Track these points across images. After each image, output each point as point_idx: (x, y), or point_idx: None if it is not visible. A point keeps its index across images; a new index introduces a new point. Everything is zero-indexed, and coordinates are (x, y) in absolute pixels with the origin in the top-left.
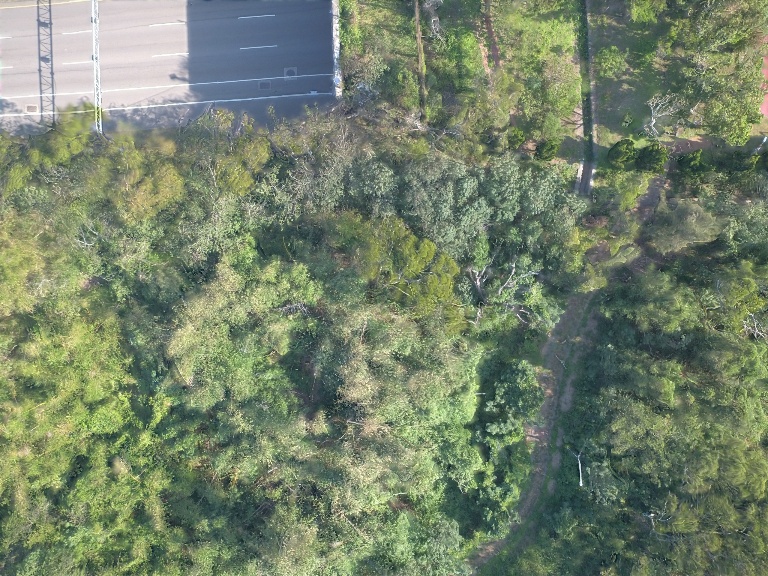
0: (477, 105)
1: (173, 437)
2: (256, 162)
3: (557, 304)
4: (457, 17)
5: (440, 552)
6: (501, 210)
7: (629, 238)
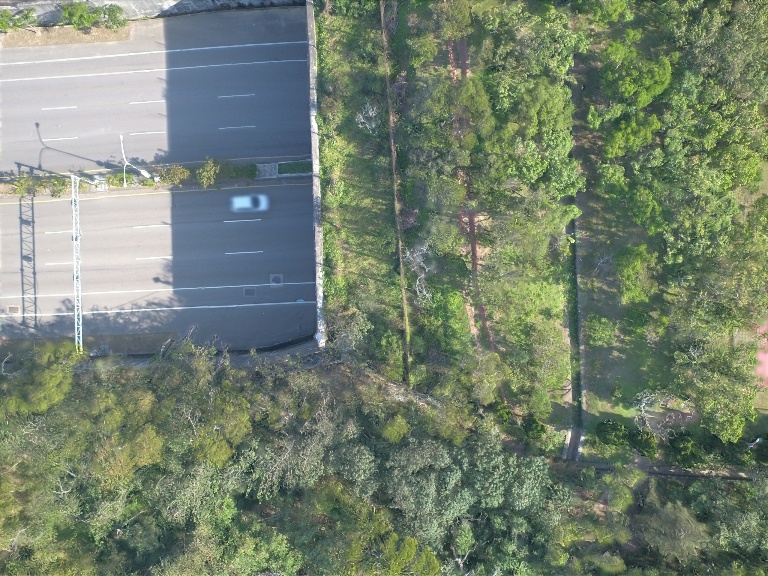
0: (462, 379)
1: None
2: (235, 432)
3: (543, 574)
4: (443, 274)
5: None
6: None
7: None
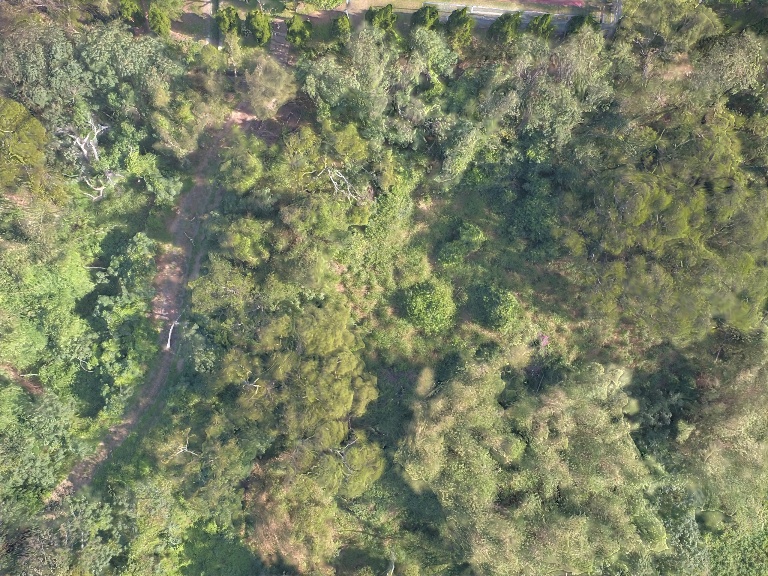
0: None
1: None
2: None
3: (182, 180)
4: None
5: (50, 427)
6: (98, 75)
7: (226, 103)
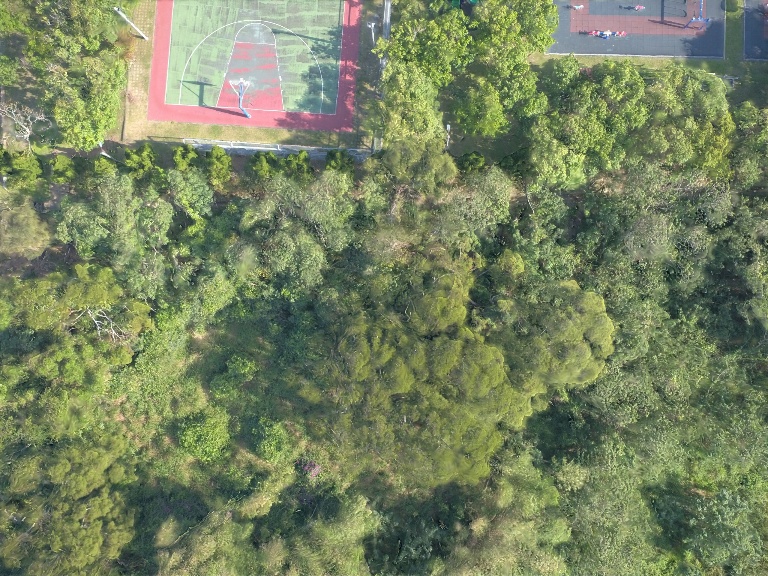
0: None
1: None
2: None
3: None
4: None
5: None
6: None
7: None
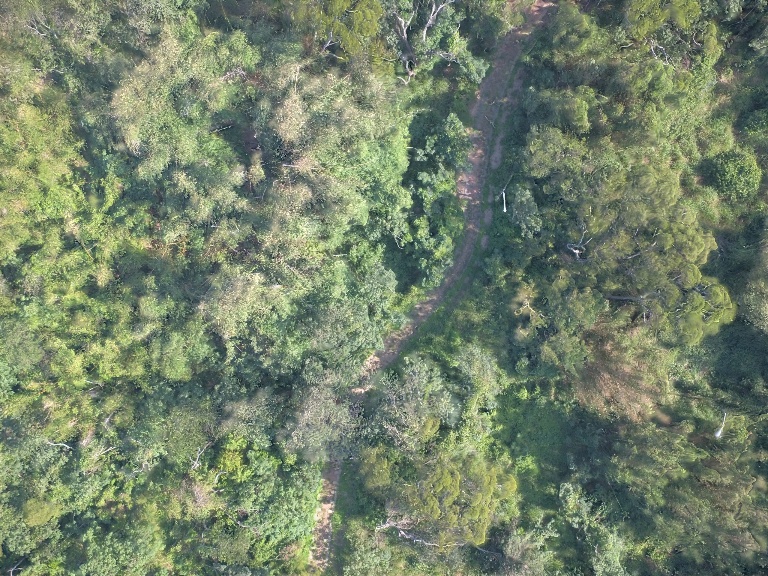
0: None
1: (124, 215)
2: None
3: None
4: None
5: (377, 297)
6: None
7: None
